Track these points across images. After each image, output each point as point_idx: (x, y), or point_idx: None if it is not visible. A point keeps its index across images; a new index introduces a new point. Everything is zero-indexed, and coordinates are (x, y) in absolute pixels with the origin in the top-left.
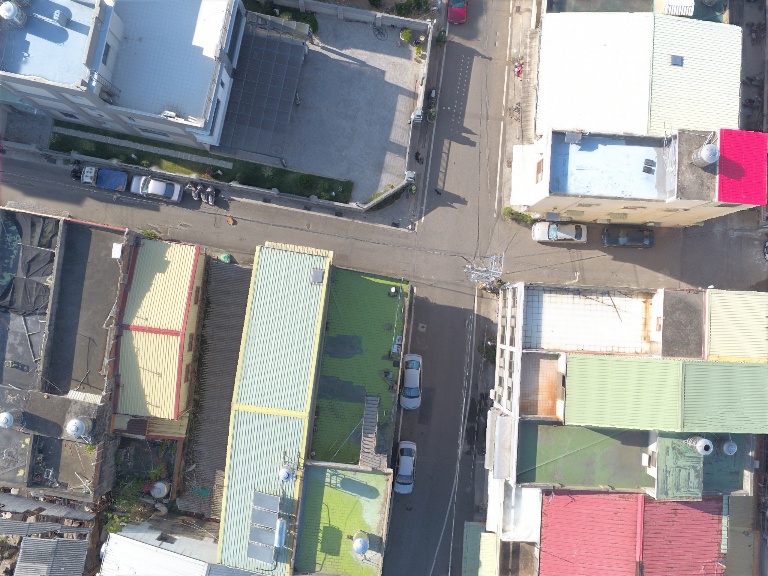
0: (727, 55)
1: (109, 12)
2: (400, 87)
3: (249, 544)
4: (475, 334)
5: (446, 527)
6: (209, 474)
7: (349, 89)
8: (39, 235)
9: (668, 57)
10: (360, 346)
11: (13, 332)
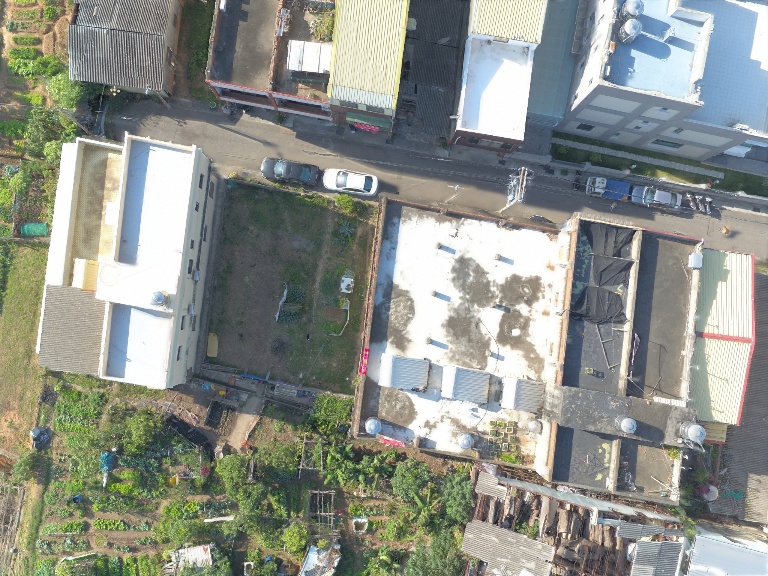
0: None
1: None
2: None
3: None
4: None
5: None
6: (741, 478)
7: None
8: (613, 245)
9: None
10: None
11: (587, 340)
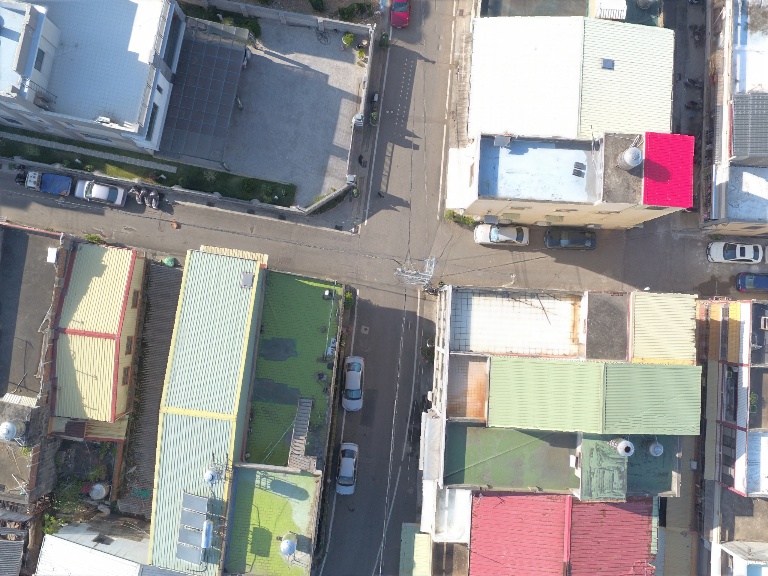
0: (658, 58)
1: (41, 19)
2: (343, 91)
3: (178, 545)
4: (418, 336)
5: (388, 528)
6: (149, 476)
7: (292, 93)
8: None
9: (599, 61)
10: (295, 349)
11: None
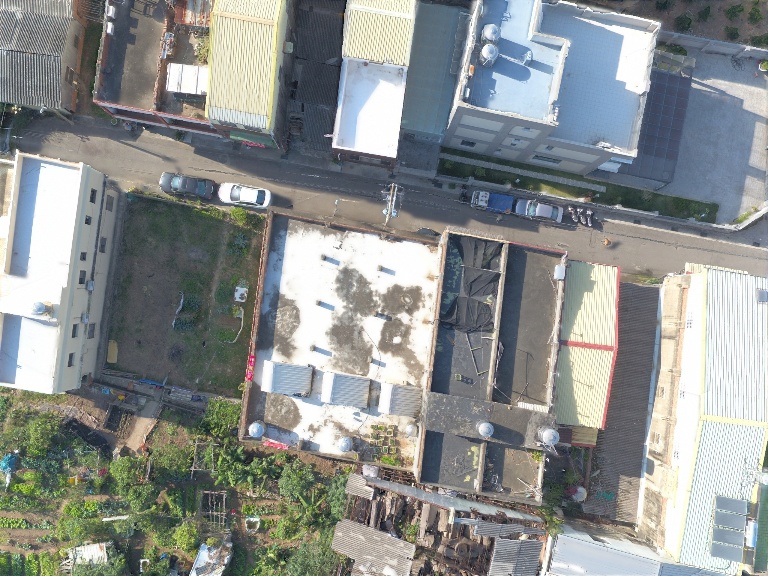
0: None
1: None
2: (757, 115)
3: (713, 544)
4: None
5: None
6: (613, 479)
7: (711, 117)
8: (482, 257)
9: None
10: None
11: (457, 348)
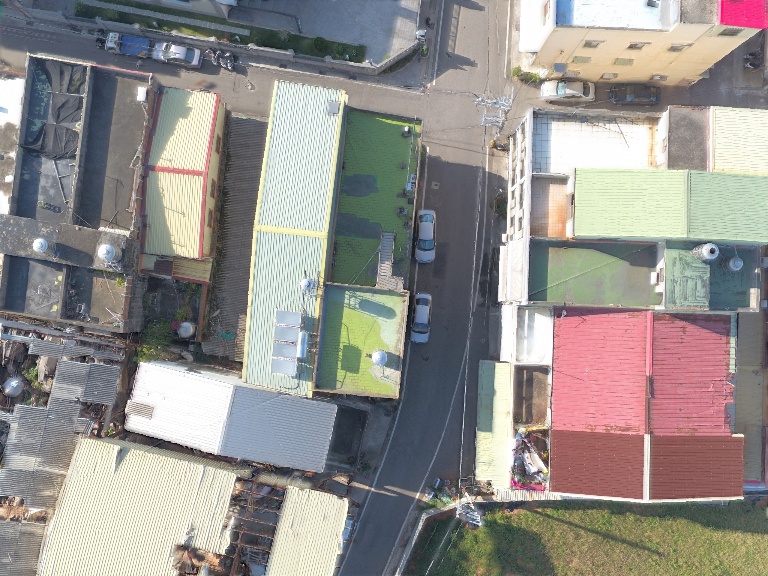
0: None
1: None
2: None
3: (272, 360)
4: (487, 191)
5: (462, 376)
6: (232, 319)
7: None
8: (68, 82)
9: None
10: (376, 185)
11: (45, 175)
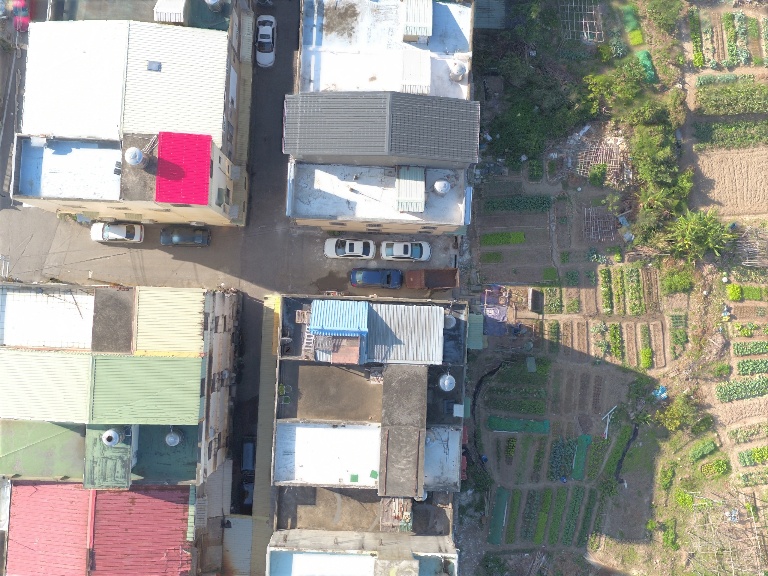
0: (209, 60)
1: None
2: None
3: None
4: None
5: None
6: None
7: None
8: None
9: (145, 63)
10: None
11: None
